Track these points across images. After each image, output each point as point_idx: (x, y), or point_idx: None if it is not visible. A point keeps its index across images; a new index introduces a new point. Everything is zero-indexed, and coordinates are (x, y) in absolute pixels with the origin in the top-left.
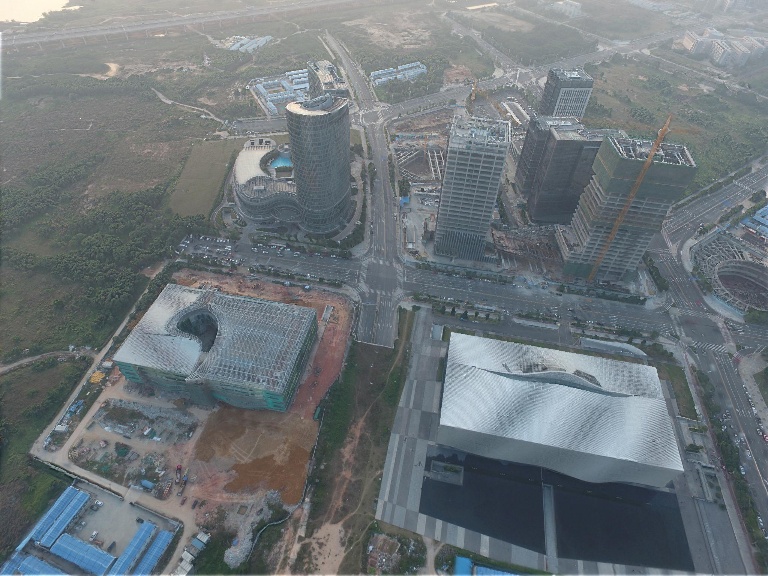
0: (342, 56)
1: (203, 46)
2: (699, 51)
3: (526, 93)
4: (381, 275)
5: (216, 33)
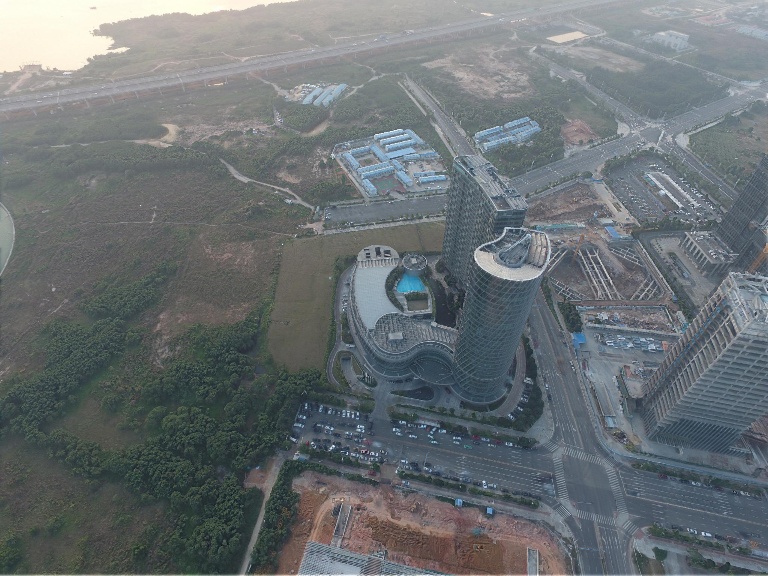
0: (432, 109)
1: (271, 99)
2: None
3: None
4: (587, 482)
5: (282, 81)
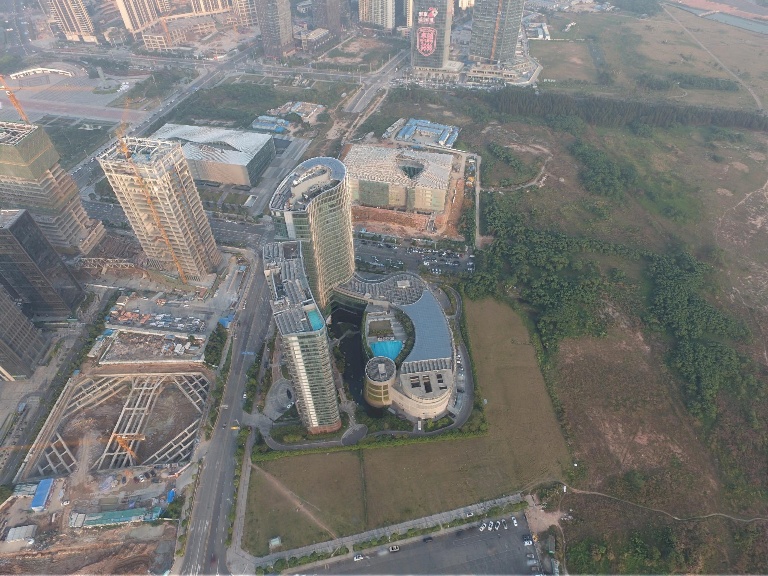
0: None
1: None
2: None
3: None
4: None
5: None
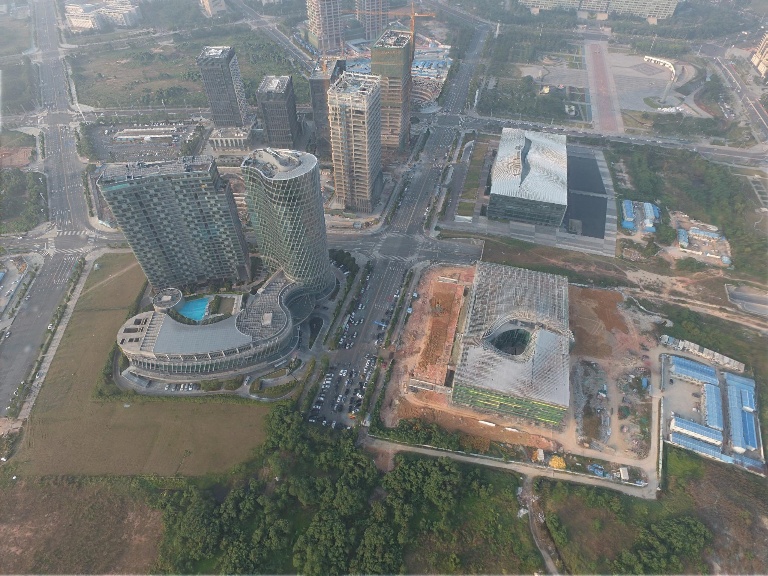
0: None
1: None
2: (102, 25)
3: (103, 122)
4: (397, 246)
5: None
